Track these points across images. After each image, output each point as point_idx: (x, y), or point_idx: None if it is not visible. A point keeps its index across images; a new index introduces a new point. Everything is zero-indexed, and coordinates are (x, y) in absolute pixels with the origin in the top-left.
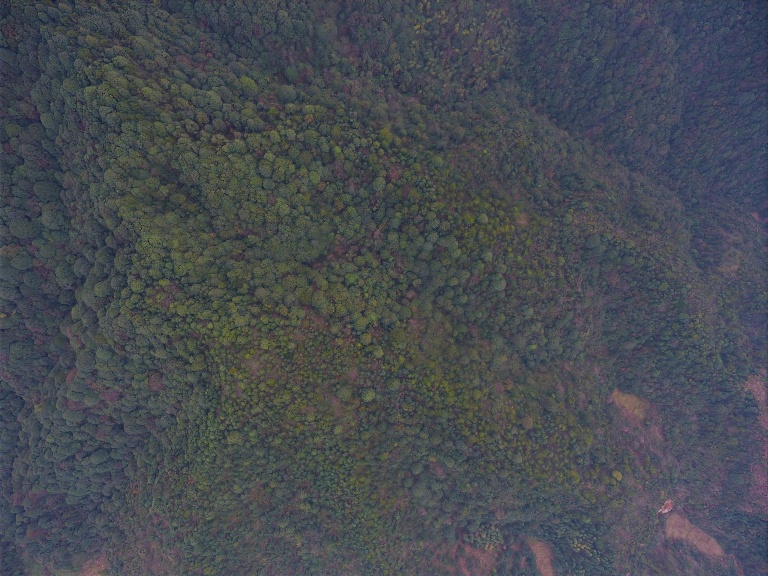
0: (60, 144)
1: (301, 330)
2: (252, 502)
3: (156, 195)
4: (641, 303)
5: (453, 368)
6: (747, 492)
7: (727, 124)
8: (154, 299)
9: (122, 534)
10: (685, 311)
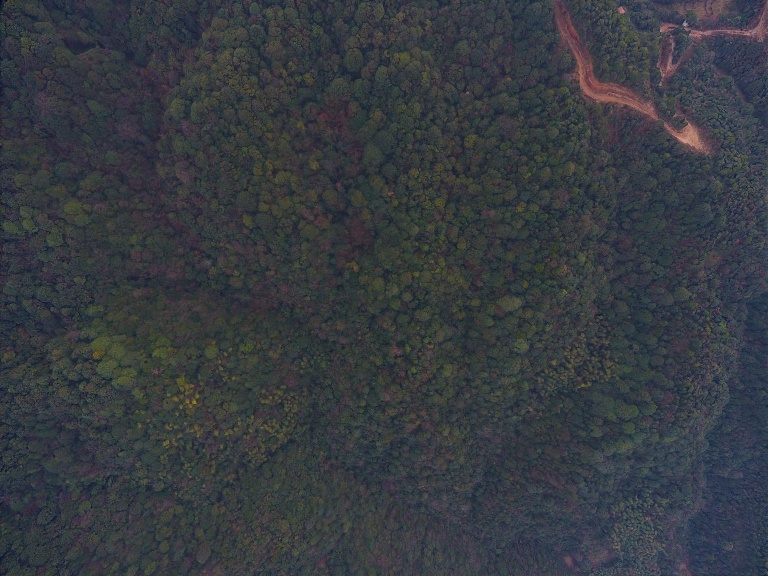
0: None
1: None
2: None
3: None
4: None
5: None
6: None
7: (522, 501)
8: None
9: None
10: None
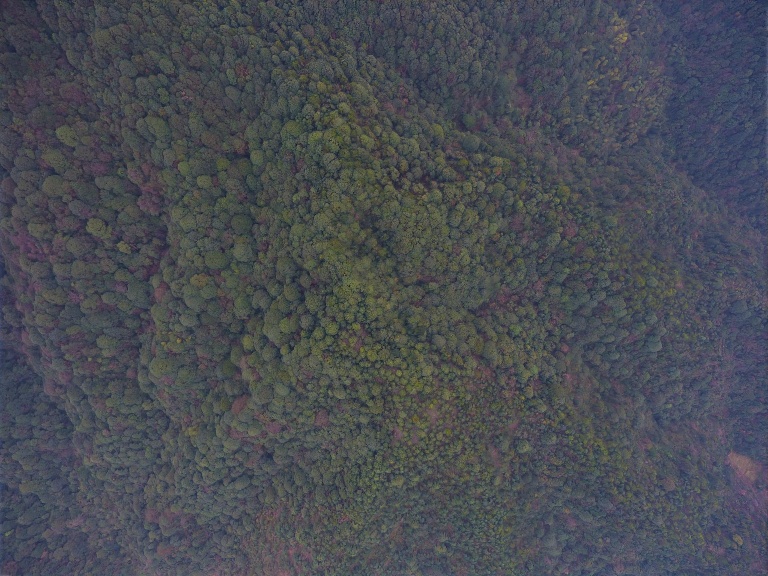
0: (266, 181)
1: (473, 380)
2: (391, 541)
3: (357, 240)
4: None
5: (604, 426)
6: None
7: None
8: (346, 342)
9: (245, 557)
10: None
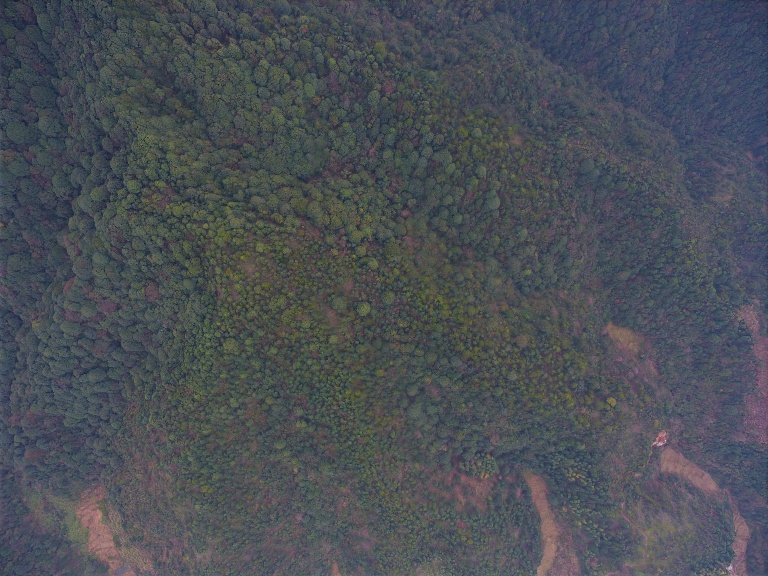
0: (56, 46)
1: (296, 238)
2: (248, 419)
3: (152, 96)
4: (635, 231)
5: (448, 284)
6: (741, 422)
7: (720, 57)
8: (150, 200)
9: (120, 459)
10: (678, 237)
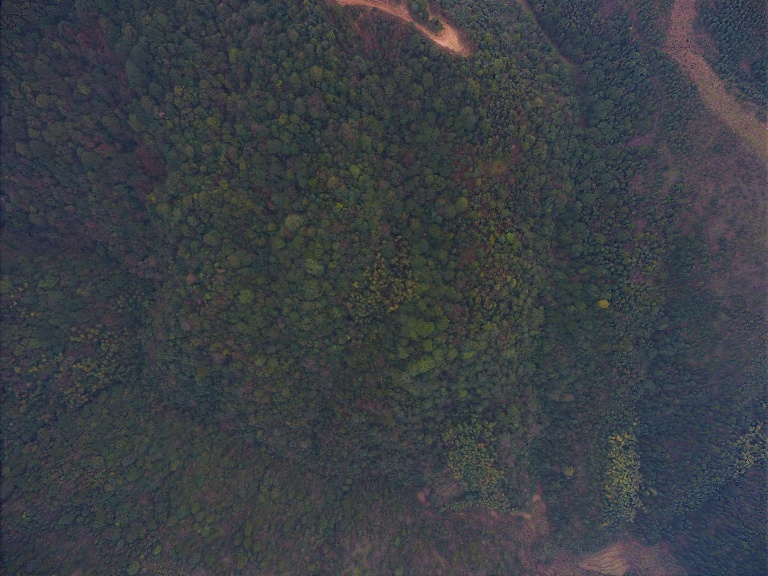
0: None
1: None
2: None
3: None
4: None
5: None
6: None
7: (353, 433)
8: None
9: None
10: None
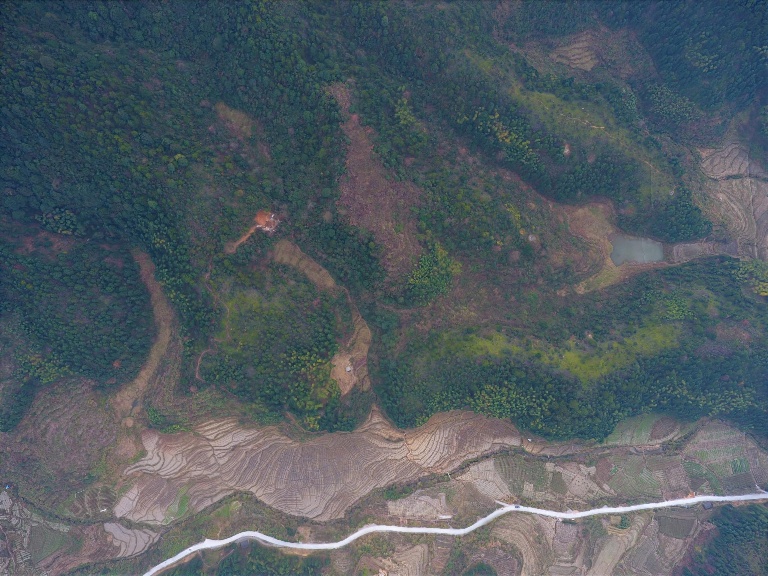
0: None
1: None
2: None
3: None
4: None
5: None
6: (332, 203)
7: None
8: None
9: None
10: None
